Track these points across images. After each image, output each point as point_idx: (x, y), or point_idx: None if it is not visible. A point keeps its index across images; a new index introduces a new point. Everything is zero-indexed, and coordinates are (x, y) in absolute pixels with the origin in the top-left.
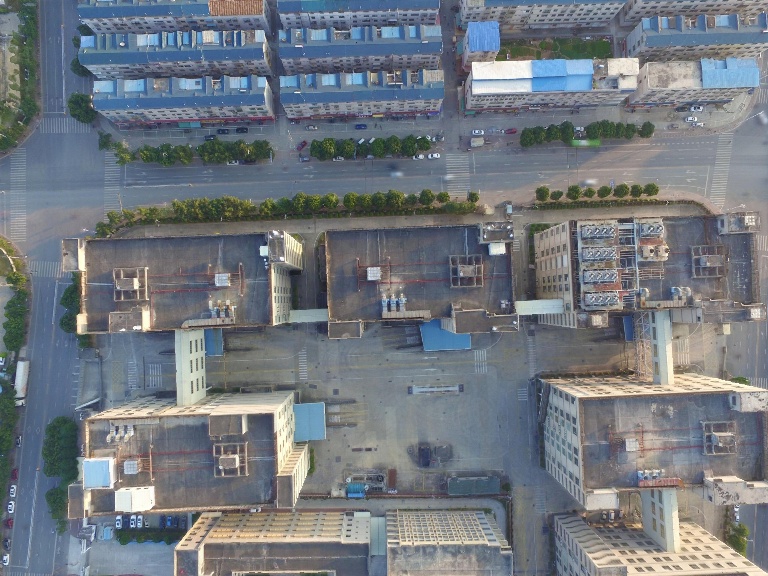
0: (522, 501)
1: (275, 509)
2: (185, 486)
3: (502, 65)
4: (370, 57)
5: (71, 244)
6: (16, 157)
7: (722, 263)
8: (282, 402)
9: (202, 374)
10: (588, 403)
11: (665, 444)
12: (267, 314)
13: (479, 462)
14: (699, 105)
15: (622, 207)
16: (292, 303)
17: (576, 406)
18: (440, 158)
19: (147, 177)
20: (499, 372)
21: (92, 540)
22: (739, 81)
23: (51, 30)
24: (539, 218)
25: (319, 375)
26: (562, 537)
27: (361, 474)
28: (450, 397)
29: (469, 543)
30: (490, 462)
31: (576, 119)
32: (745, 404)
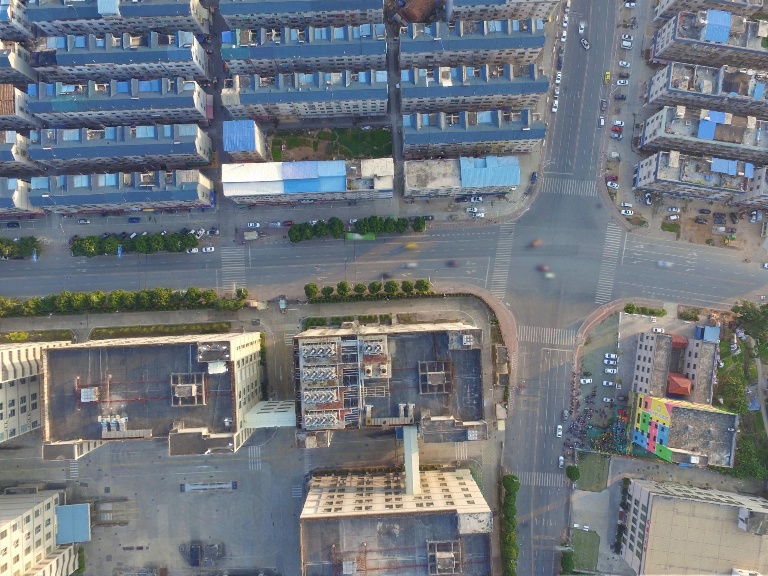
0: None
1: None
2: None
3: (252, 167)
4: (126, 156)
5: None
6: None
7: (444, 381)
8: (18, 516)
9: None
10: (312, 522)
11: (390, 563)
12: None
13: (252, 560)
14: (478, 196)
15: (400, 300)
16: None
17: None
18: (215, 251)
19: None
20: (273, 469)
21: None
22: (499, 180)
23: None
24: (315, 312)
25: (90, 473)
26: None
27: (132, 573)
28: (223, 494)
29: None
30: (263, 560)
31: (354, 210)
32: (464, 526)
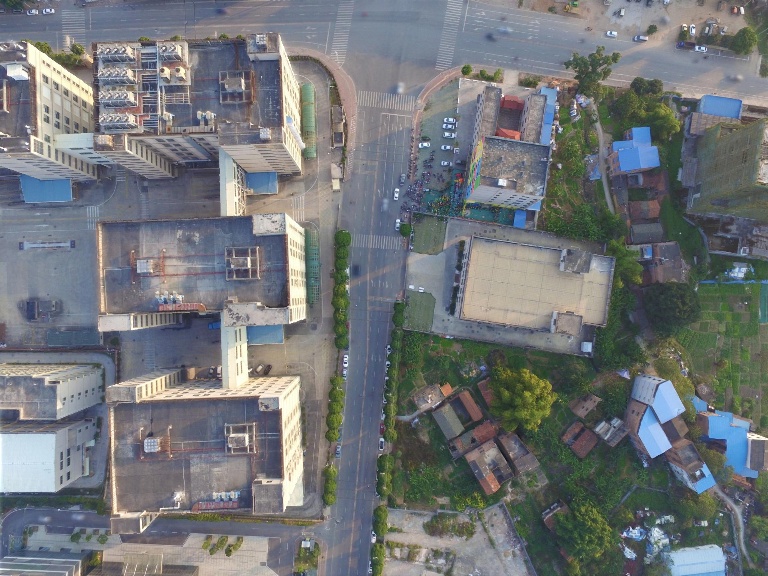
0: (131, 356)
1: None
2: None
3: None
4: None
5: None
6: None
7: (241, 85)
8: None
9: None
10: (113, 229)
11: (189, 270)
12: None
13: (89, 317)
14: None
15: None
16: None
17: (101, 232)
18: (55, 14)
19: None
20: None
21: None
22: None
23: None
24: None
25: None
26: None
27: None
28: (61, 253)
29: (14, 375)
30: None
31: None
32: (257, 226)
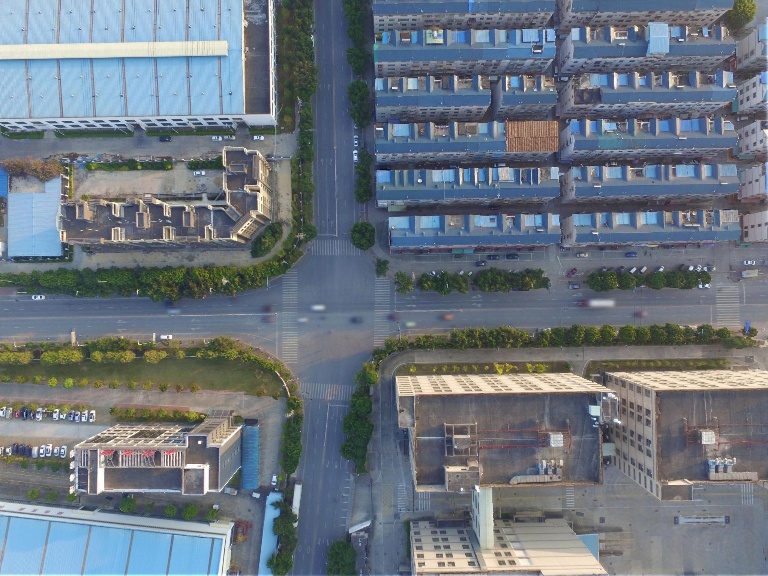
0: None
1: None
2: None
3: None
4: (662, 195)
5: (407, 401)
6: (288, 279)
7: None
8: (587, 549)
9: None
10: None
11: None
12: (592, 471)
13: None
14: None
15: None
16: None
17: None
18: (710, 288)
19: (417, 301)
20: (766, 505)
21: None
22: None
23: (323, 152)
24: None
25: (586, 503)
26: None
27: None
28: (716, 528)
29: None
30: None
31: None
32: None
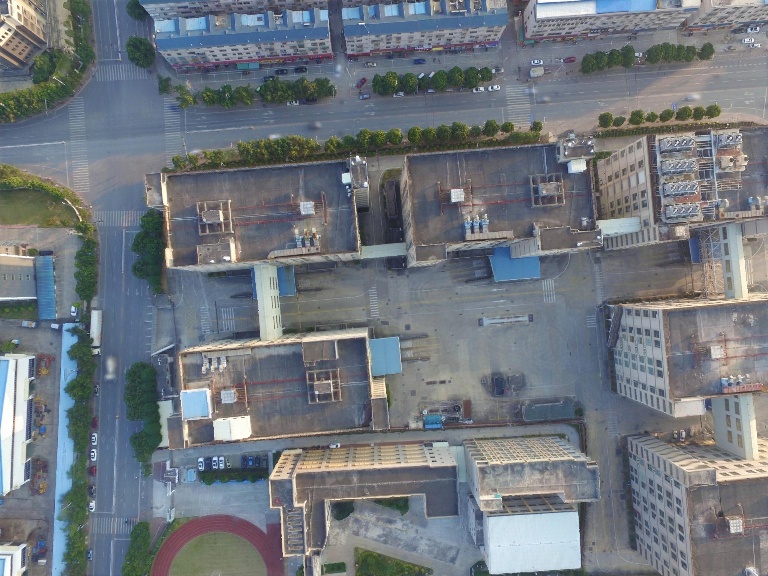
0: (595, 425)
1: (354, 444)
2: (280, 414)
3: None
4: None
5: (154, 179)
6: (74, 107)
7: None
8: (365, 332)
9: (278, 313)
10: (671, 315)
11: (747, 351)
12: (351, 242)
13: (551, 389)
14: (756, 26)
15: None
16: None
17: (659, 319)
18: (500, 90)
19: (207, 121)
20: (567, 300)
21: (176, 483)
22: None
23: None
24: (601, 146)
25: (390, 311)
26: (638, 455)
27: (436, 406)
28: (520, 327)
29: (556, 459)
30: (562, 389)
31: (634, 45)
32: None
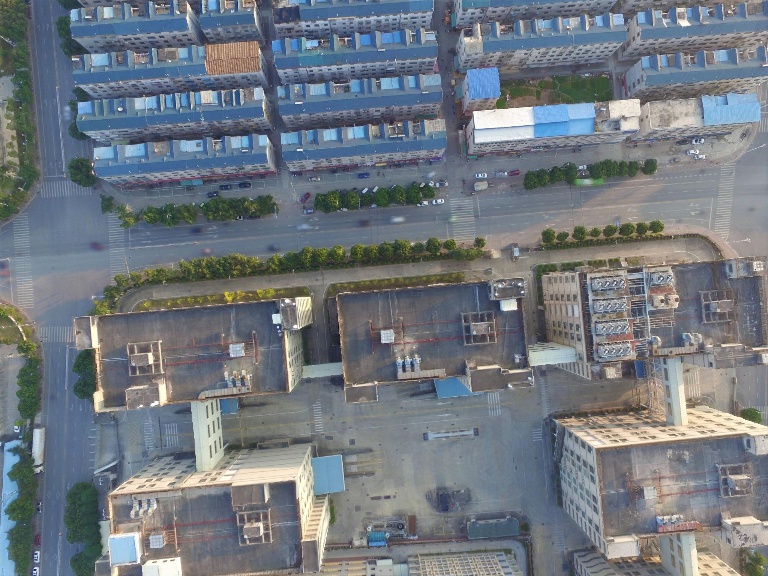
0: (541, 540)
1: None
2: (211, 555)
3: (504, 113)
4: (370, 109)
5: (83, 322)
6: (18, 223)
7: (732, 308)
8: (301, 463)
9: (219, 434)
10: (605, 452)
11: (682, 489)
12: (283, 380)
13: (497, 504)
14: (700, 137)
15: (628, 243)
16: (304, 356)
17: (593, 456)
18: (444, 203)
19: (152, 237)
20: (513, 414)
21: None
22: (740, 116)
23: (46, 92)
24: (546, 259)
25: (335, 426)
26: (583, 575)
27: (381, 522)
28: (465, 441)
29: None
30: (508, 503)
31: (578, 157)
32: (760, 447)
